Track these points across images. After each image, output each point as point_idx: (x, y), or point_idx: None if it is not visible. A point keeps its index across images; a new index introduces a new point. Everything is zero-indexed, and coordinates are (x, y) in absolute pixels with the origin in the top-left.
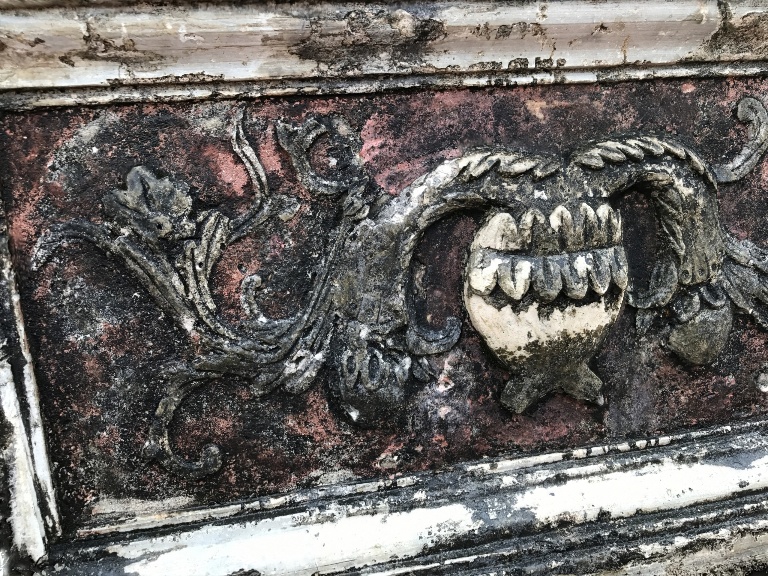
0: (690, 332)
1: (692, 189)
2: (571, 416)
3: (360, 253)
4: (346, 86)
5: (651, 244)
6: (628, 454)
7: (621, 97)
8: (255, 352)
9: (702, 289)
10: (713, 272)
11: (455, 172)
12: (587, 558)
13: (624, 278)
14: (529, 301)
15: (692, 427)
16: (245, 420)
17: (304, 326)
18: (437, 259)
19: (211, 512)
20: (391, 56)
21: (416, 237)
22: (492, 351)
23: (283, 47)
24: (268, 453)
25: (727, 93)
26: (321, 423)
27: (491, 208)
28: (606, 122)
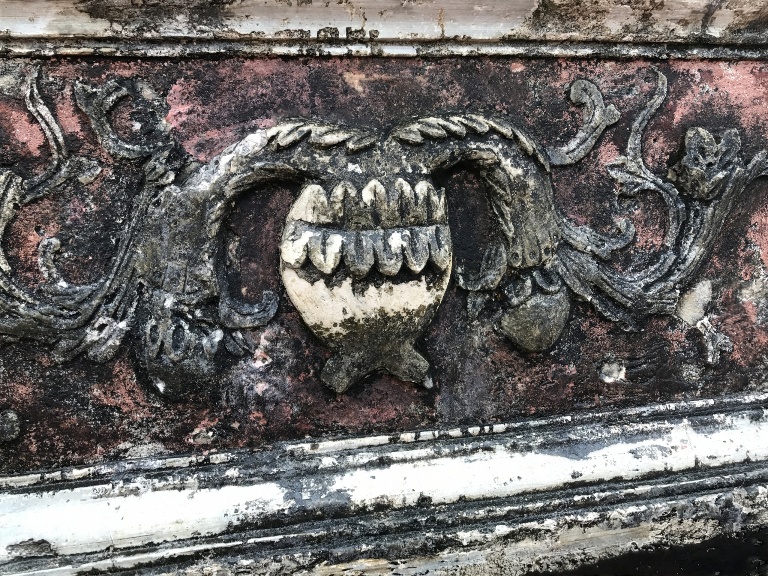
0: (521, 316)
1: (521, 170)
2: (400, 399)
3: (164, 220)
4: (146, 48)
5: (483, 225)
6: (459, 440)
7: (446, 73)
8: (54, 317)
9: (535, 273)
10: (545, 256)
11: (265, 141)
12: (399, 543)
13: (445, 257)
14: (342, 276)
15: (531, 416)
16: (46, 387)
17: (106, 292)
18: (251, 231)
19: (8, 480)
20: (189, 19)
21: (223, 206)
22: (308, 327)
23: (69, 4)
24: (71, 422)
25: (559, 74)
26: (129, 394)
27: (305, 180)
28: (431, 98)
